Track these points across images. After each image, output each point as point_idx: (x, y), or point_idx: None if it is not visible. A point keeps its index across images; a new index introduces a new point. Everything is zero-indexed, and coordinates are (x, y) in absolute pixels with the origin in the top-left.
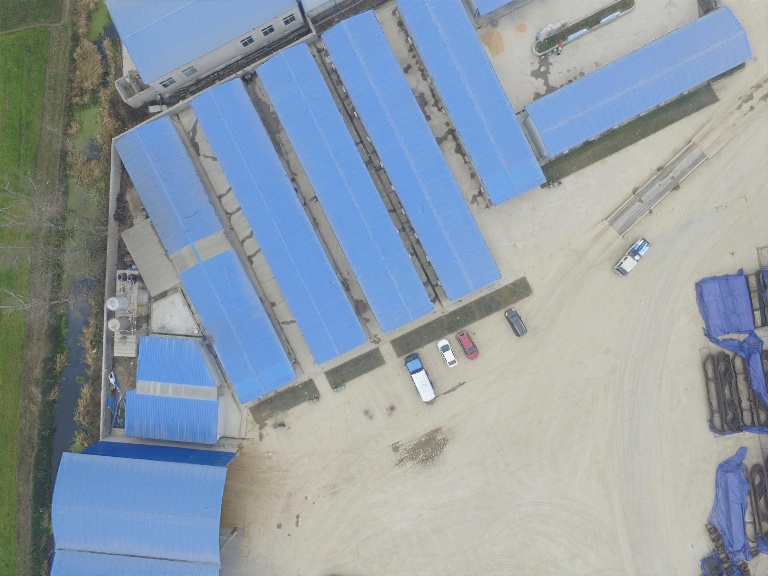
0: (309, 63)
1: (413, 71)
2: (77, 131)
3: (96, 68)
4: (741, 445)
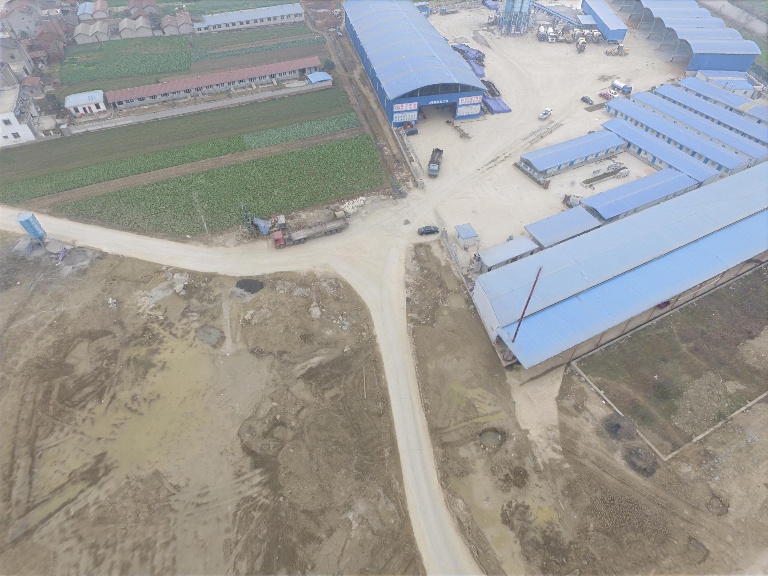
0: None
1: None
2: None
3: None
4: None
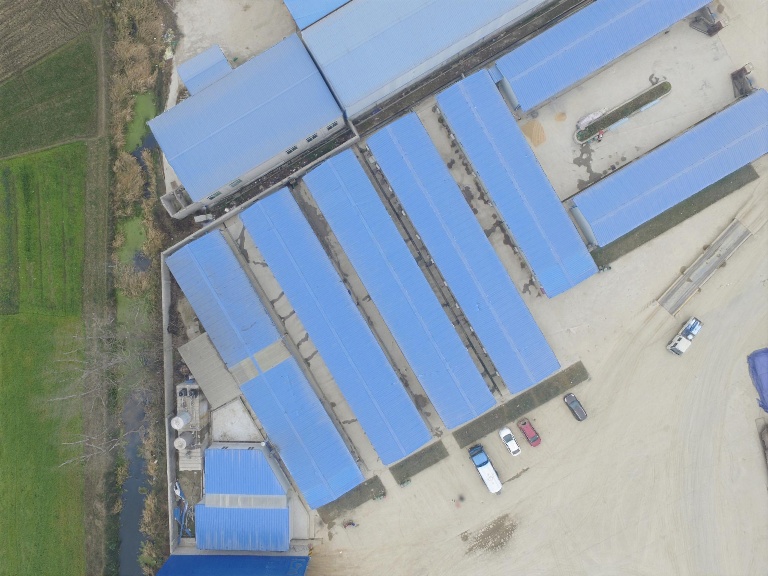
0: (356, 169)
1: (457, 166)
2: (122, 244)
3: (137, 180)
4: None
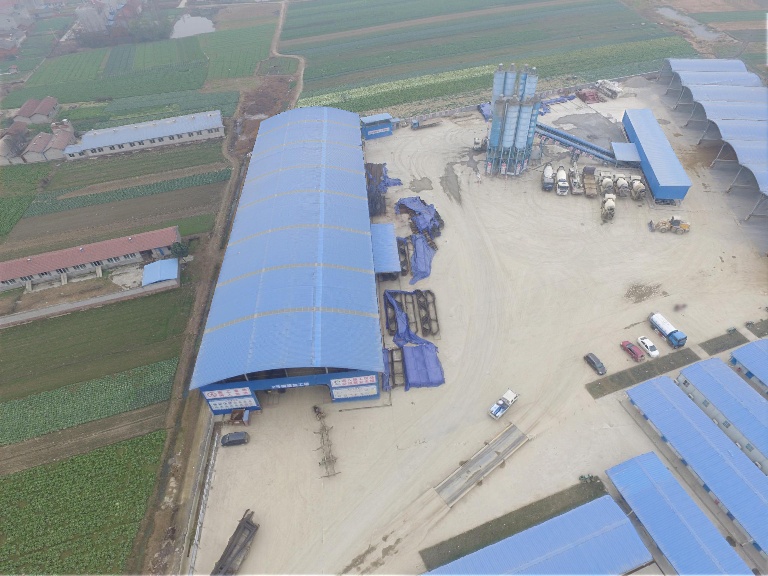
0: None
1: None
2: None
3: None
4: (413, 286)
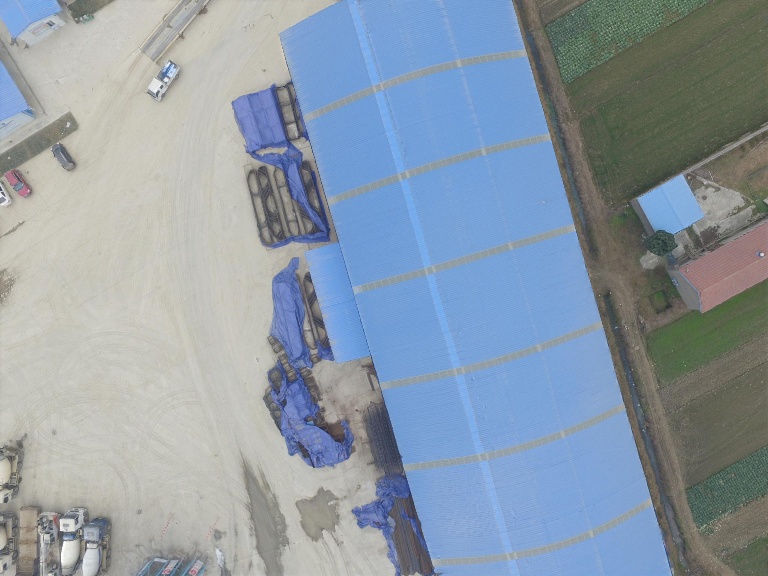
0: None
1: None
2: None
3: None
4: (293, 256)
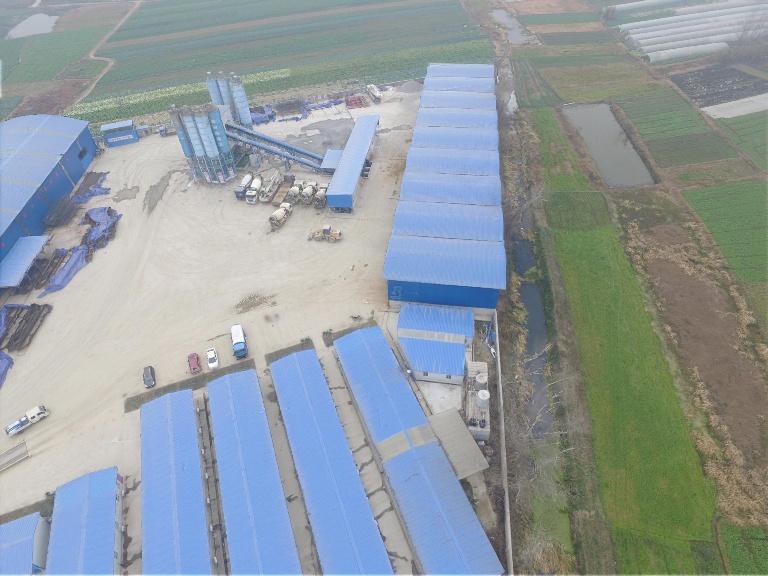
0: None
1: None
2: None
3: None
4: (39, 299)
